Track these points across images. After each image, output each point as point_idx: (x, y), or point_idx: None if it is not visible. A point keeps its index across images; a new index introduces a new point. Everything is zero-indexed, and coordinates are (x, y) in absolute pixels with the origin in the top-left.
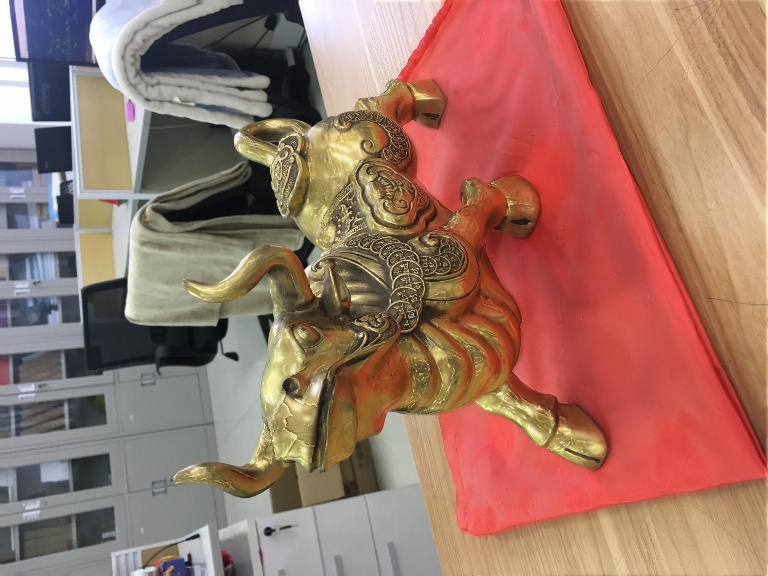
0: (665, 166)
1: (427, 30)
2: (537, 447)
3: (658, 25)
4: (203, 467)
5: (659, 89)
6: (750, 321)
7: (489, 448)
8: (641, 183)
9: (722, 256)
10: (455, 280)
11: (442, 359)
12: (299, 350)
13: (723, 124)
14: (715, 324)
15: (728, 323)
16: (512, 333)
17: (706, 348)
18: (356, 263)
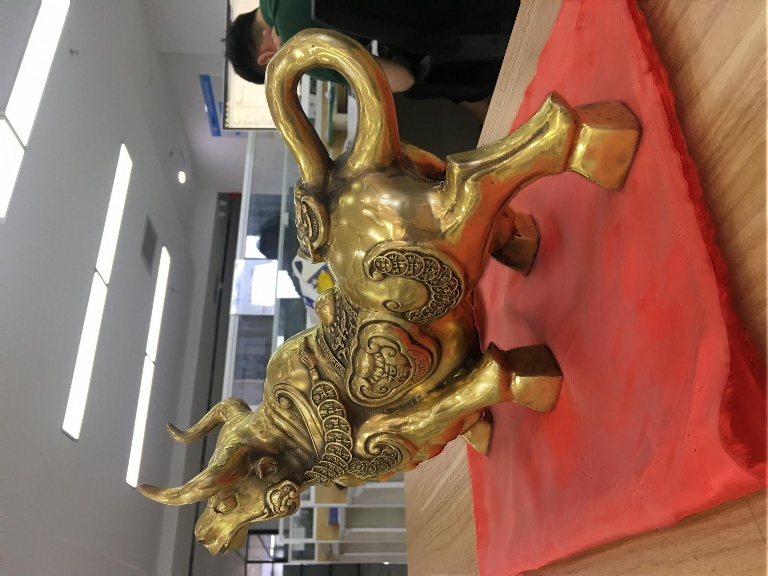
0: None
1: (674, 118)
2: None
3: None
4: None
5: None
6: None
7: None
8: None
9: None
10: None
11: None
12: None
13: None
14: None
15: None
16: None
17: None
18: (306, 424)
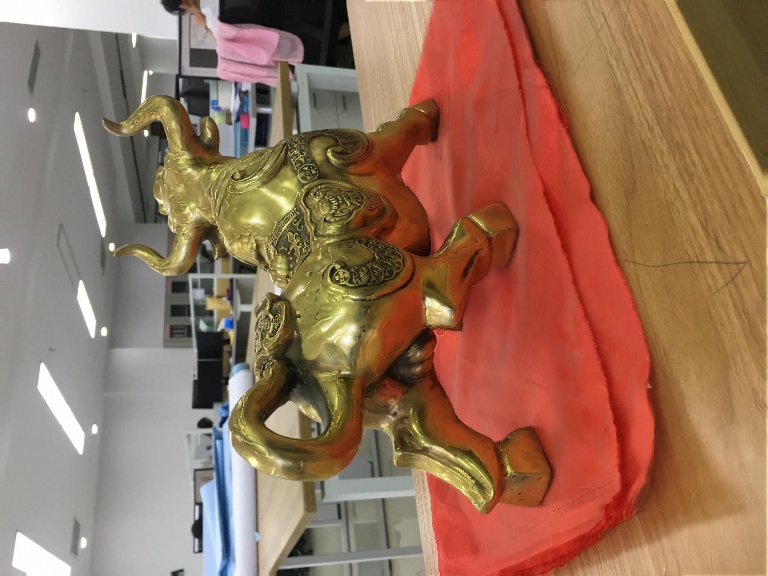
0: None
1: None
2: (449, 78)
3: None
4: None
5: None
6: None
7: (468, 30)
8: None
9: None
10: None
11: None
12: None
13: None
14: None
15: None
16: None
17: None
18: None
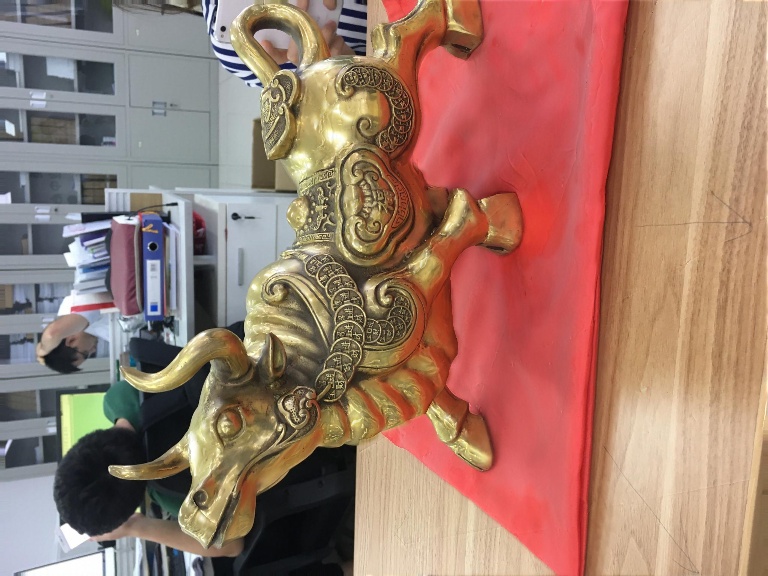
0: (628, 320)
1: None
2: None
3: (690, 189)
4: (133, 471)
5: (658, 250)
6: (622, 492)
7: None
8: (604, 312)
9: (629, 431)
10: (393, 350)
11: (358, 422)
12: (219, 444)
13: (687, 338)
14: (599, 468)
15: (608, 477)
16: (437, 384)
17: (582, 483)
18: (307, 302)
